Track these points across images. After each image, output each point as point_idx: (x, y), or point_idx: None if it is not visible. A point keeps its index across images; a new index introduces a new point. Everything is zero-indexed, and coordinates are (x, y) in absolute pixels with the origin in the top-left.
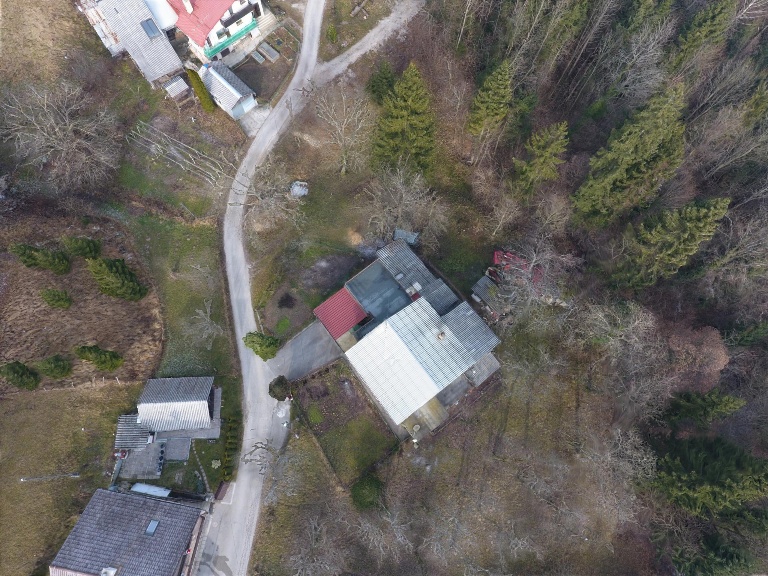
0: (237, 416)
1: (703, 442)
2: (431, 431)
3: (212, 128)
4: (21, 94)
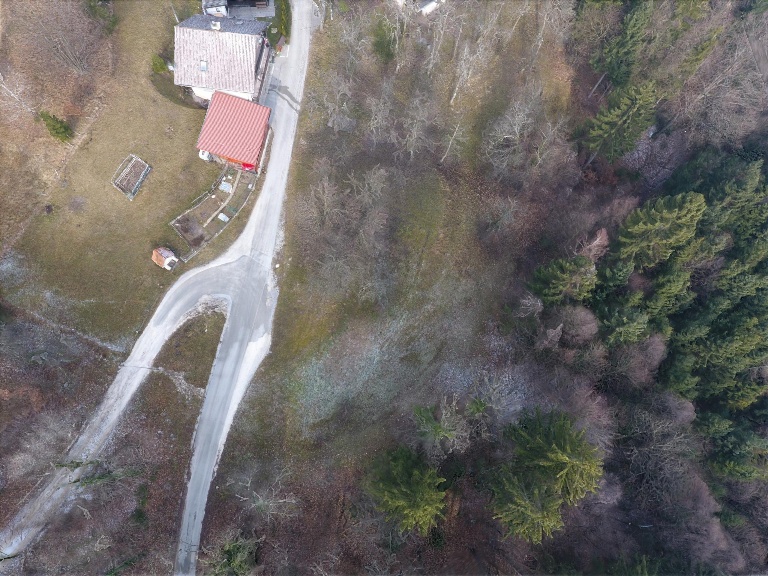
0: None
1: None
2: (429, 21)
3: None
4: None
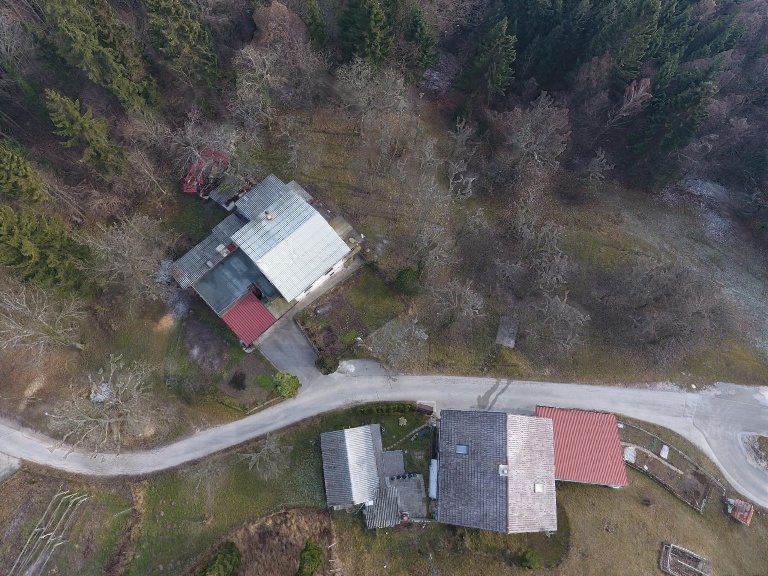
0: None
1: (342, 35)
2: None
3: None
4: None
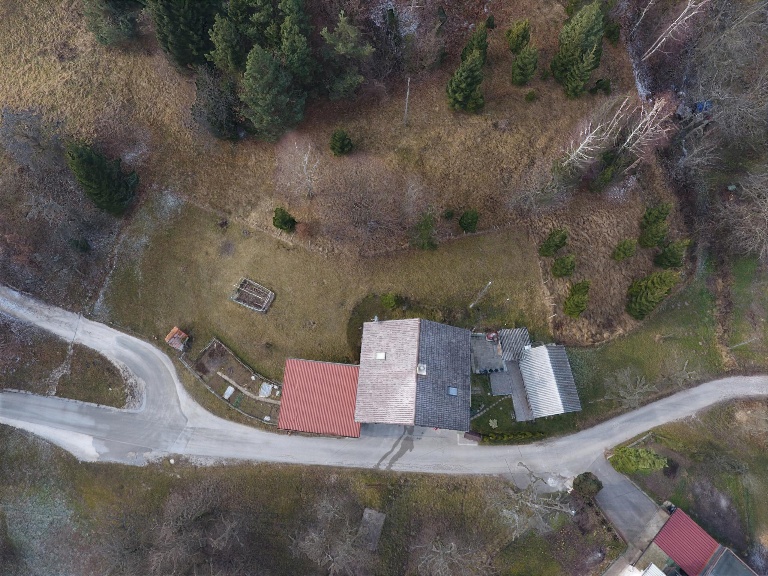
0: (542, 436)
1: None
2: None
3: None
4: None
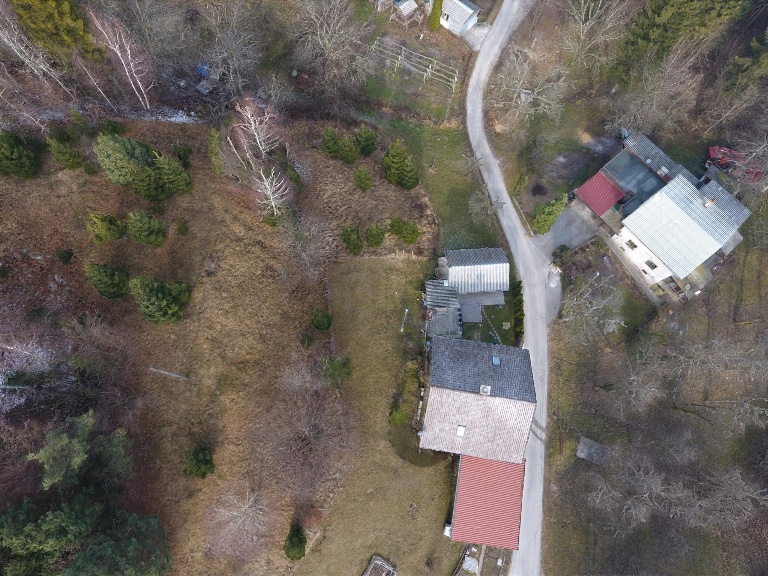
0: None
1: None
2: (682, 299)
3: (438, 44)
4: (273, 13)
